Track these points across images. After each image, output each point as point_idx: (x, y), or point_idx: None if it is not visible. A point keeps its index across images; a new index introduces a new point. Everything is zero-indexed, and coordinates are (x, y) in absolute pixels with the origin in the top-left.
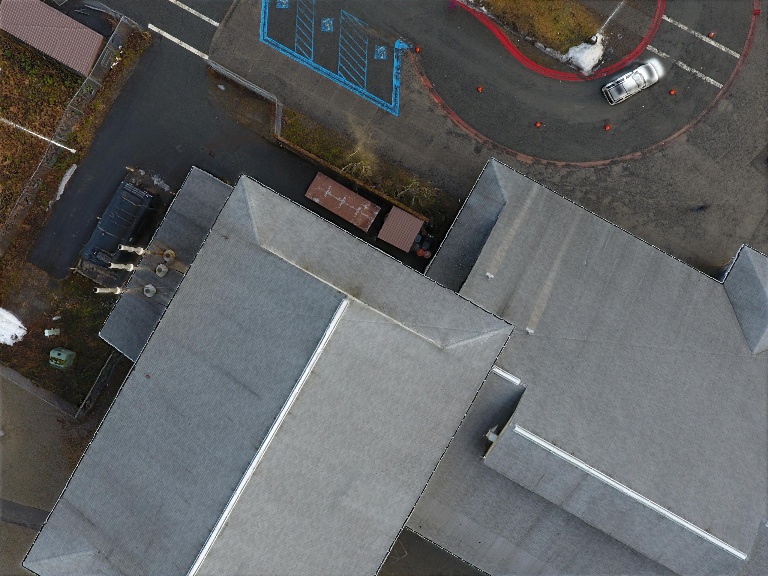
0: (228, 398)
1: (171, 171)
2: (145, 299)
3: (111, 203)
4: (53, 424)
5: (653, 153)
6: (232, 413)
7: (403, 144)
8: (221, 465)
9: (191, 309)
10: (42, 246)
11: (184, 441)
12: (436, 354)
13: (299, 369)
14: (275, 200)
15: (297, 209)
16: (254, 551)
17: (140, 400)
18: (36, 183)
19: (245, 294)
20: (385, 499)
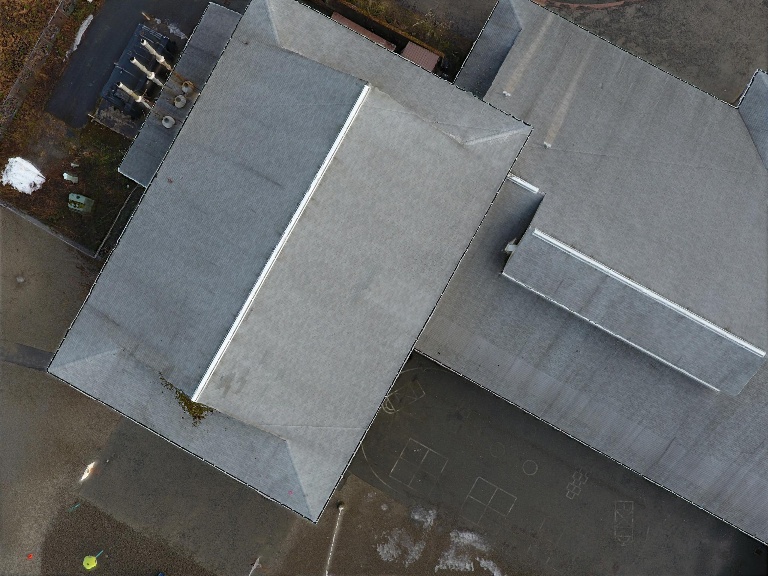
0: (251, 191)
1: (187, 20)
2: (164, 131)
3: (128, 45)
4: (72, 271)
5: None
6: (255, 205)
7: None
8: (245, 254)
9: (212, 114)
10: (59, 96)
11: (207, 236)
12: (456, 150)
13: (321, 156)
14: (294, 6)
15: (316, 15)
16: (278, 340)
17: (163, 204)
18: (53, 34)
19: (266, 93)
20: (407, 296)
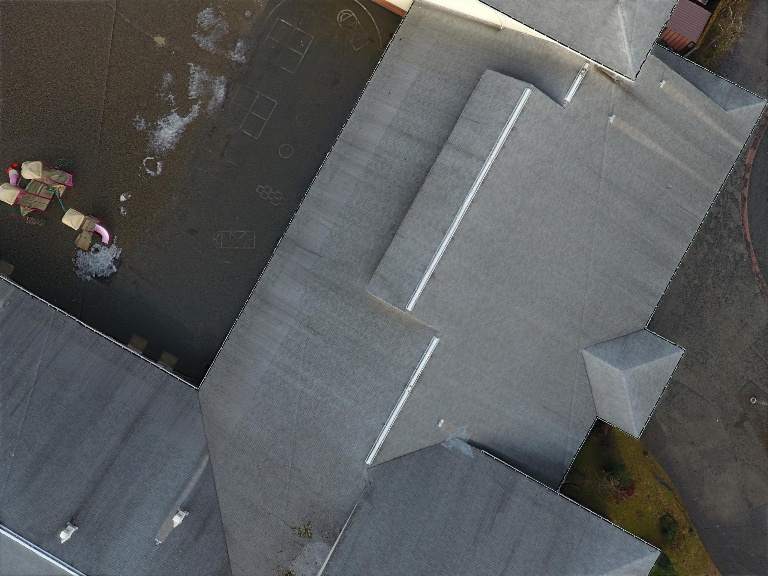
0: None
1: None
2: None
3: None
4: None
5: (759, 284)
6: None
7: (763, 36)
8: None
9: None
10: None
11: None
12: None
13: None
14: None
15: None
16: None
17: None
18: None
19: None
20: None
